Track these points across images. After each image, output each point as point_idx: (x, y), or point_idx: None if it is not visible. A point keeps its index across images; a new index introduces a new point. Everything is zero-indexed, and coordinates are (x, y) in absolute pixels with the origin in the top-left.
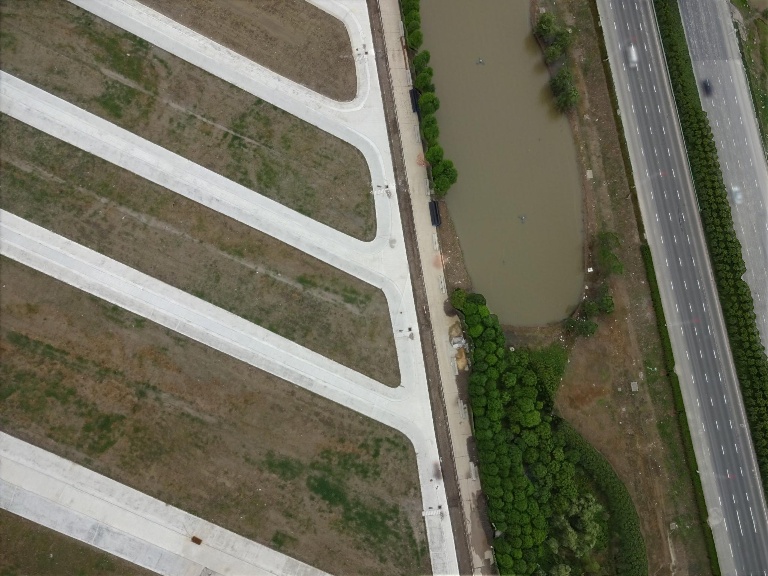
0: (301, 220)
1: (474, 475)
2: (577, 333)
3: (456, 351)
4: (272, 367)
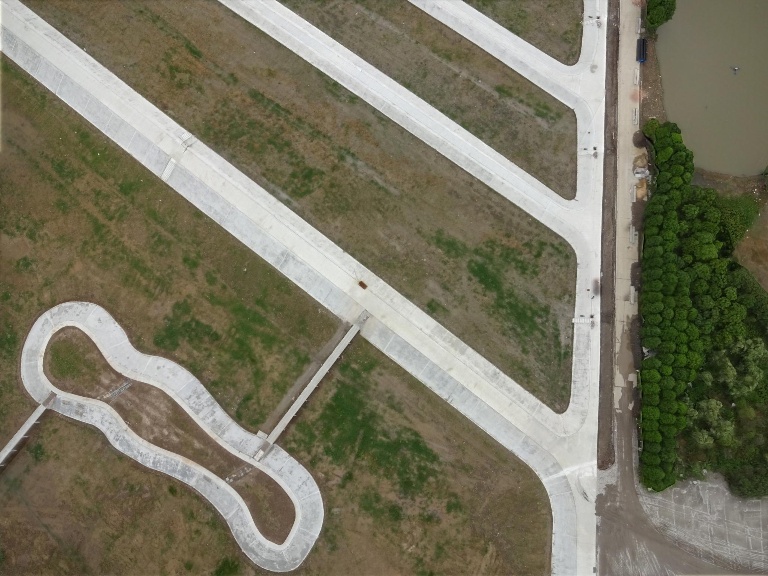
0: (510, 36)
1: (633, 298)
2: None
3: (637, 180)
4: (457, 157)
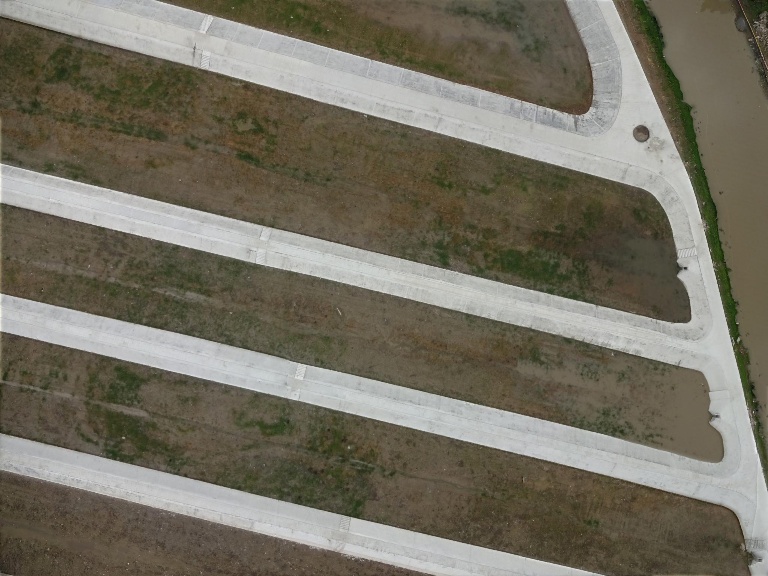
0: None
1: None
2: None
3: None
4: None
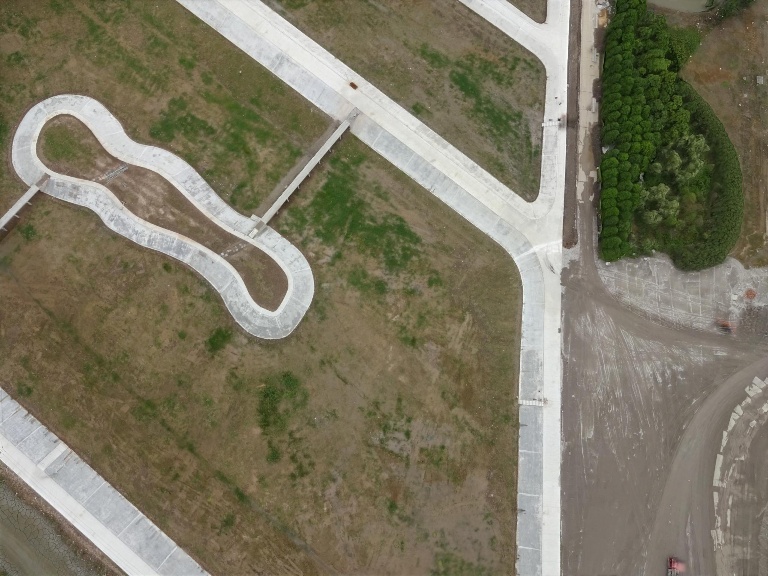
0: None
1: (594, 108)
2: (713, 24)
3: (599, 11)
4: None
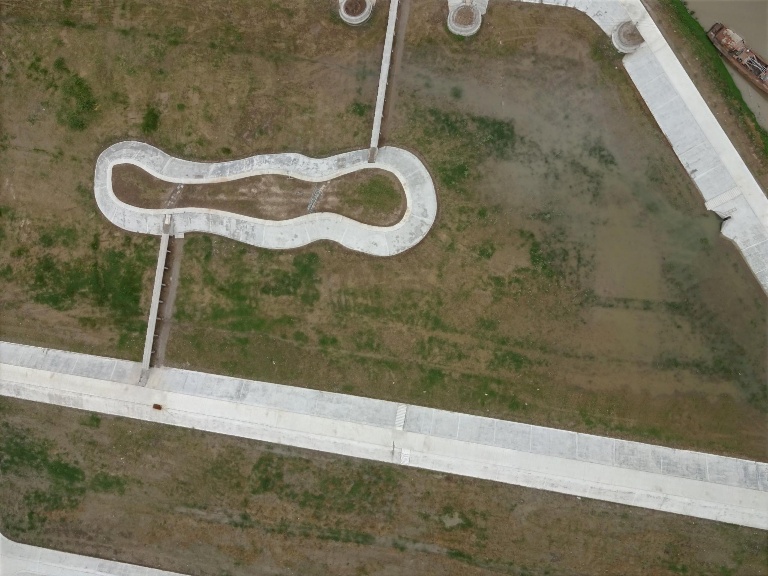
0: None
1: None
2: None
3: None
4: (138, 573)
